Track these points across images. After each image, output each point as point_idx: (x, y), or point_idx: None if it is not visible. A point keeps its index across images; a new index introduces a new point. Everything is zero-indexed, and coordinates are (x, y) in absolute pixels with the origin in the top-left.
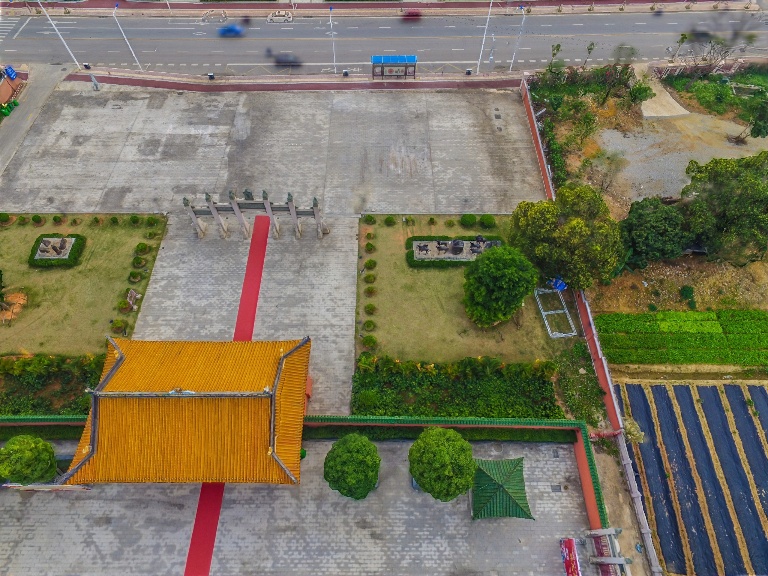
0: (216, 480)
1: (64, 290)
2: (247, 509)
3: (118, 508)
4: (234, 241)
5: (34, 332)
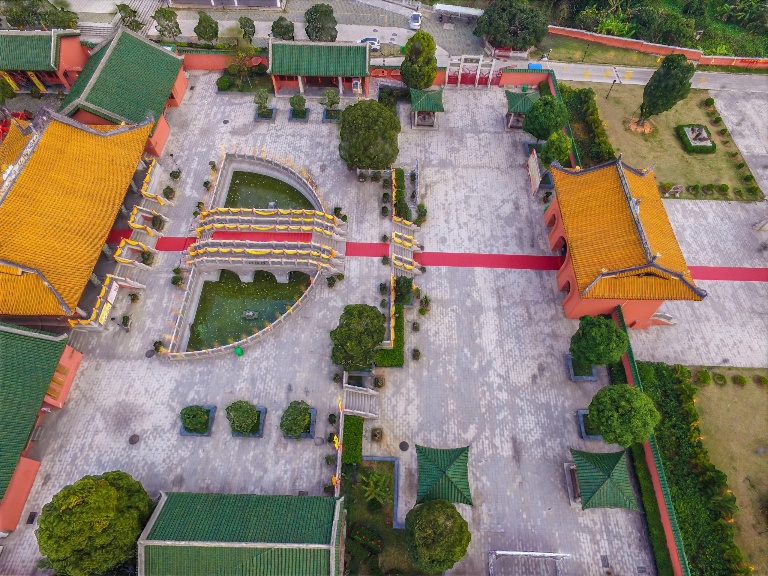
0: (571, 245)
1: (664, 151)
2: (538, 286)
3: (525, 212)
4: (763, 254)
5: (626, 143)
